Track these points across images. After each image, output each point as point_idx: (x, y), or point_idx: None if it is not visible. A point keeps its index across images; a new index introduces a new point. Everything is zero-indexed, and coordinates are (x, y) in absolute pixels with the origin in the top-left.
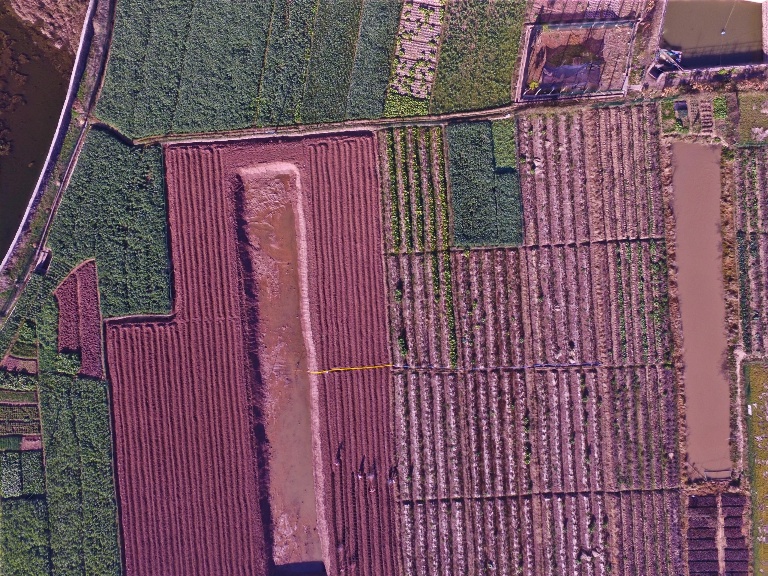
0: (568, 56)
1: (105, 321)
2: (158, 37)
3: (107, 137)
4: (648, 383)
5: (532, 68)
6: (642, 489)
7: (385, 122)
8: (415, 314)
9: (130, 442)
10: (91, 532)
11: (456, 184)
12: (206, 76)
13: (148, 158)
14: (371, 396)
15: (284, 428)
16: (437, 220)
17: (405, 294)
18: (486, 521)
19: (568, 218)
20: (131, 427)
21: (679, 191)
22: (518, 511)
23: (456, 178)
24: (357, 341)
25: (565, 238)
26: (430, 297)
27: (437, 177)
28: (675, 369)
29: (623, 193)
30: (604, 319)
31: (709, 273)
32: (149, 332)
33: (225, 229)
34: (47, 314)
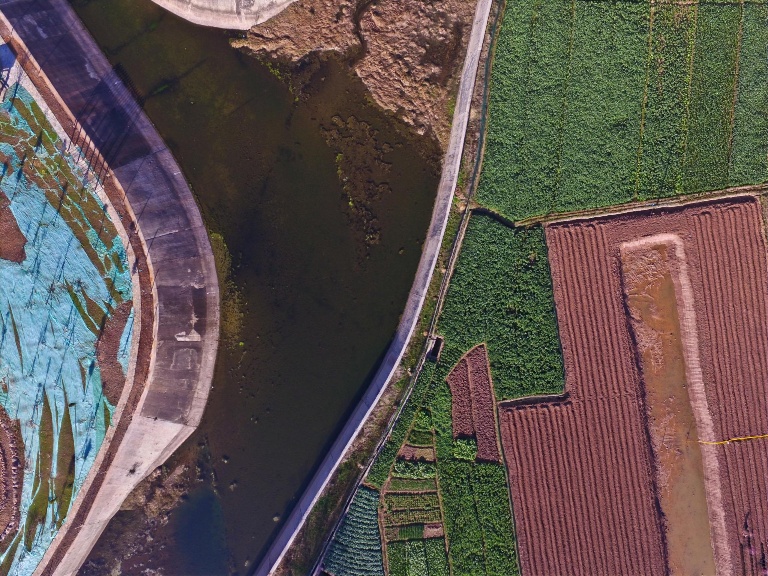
0: None
1: (497, 404)
2: (536, 119)
3: (492, 222)
4: None
5: None
6: None
7: (767, 186)
8: None
9: (532, 524)
10: None
11: None
12: (586, 154)
13: (533, 239)
14: None
15: (678, 500)
16: None
17: None
18: None
19: None
20: (533, 509)
21: None
22: None
23: None
24: (756, 409)
25: None
26: None
27: None
28: None
29: None
30: None
31: None
32: (544, 413)
33: (613, 305)
34: (441, 401)
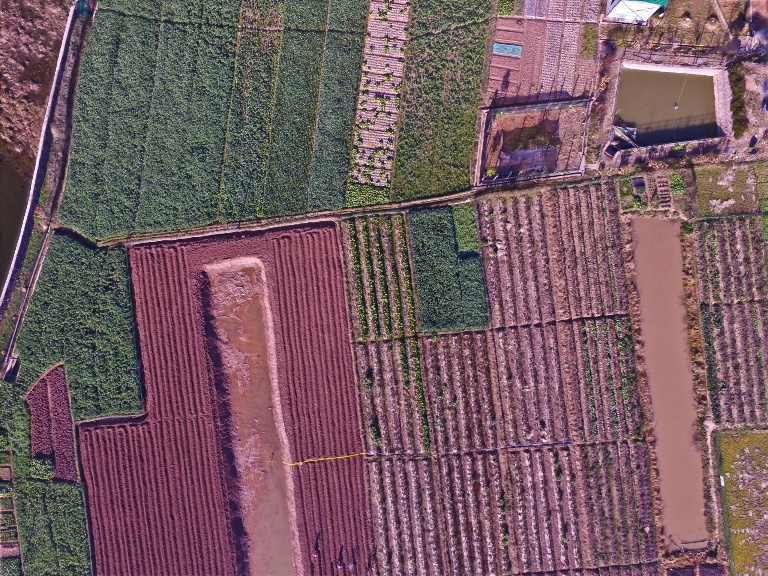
0: (524, 138)
1: (77, 424)
2: (117, 140)
3: (70, 242)
4: (620, 458)
5: (489, 152)
6: (620, 564)
7: (347, 212)
8: (386, 401)
9: (108, 544)
10: None
11: (420, 271)
12: (166, 176)
13: (112, 260)
14: (346, 485)
15: (262, 520)
16: (403, 307)
17: (375, 382)
18: None
19: (533, 298)
20: (108, 529)
21: (641, 266)
22: None
23: (420, 265)
24: (329, 431)
25: (531, 318)
26: (400, 383)
27: (401, 264)
28: (646, 443)
29: (586, 271)
30: (573, 397)
31: (675, 346)
32: (121, 433)
33: (193, 326)
34: (19, 420)
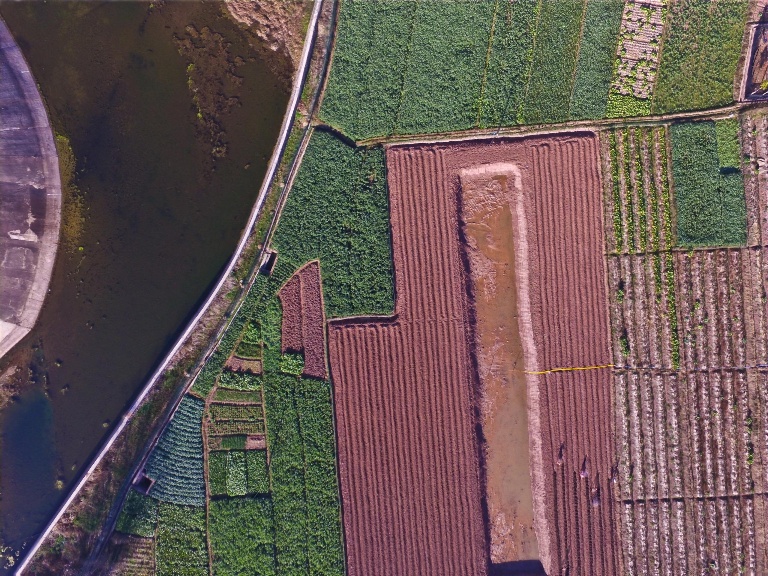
0: None
1: (327, 322)
2: (382, 39)
3: (332, 139)
4: None
5: (756, 67)
6: None
7: (607, 122)
8: (636, 314)
9: (353, 441)
10: (316, 530)
11: (680, 184)
12: (430, 77)
13: (372, 160)
14: (593, 396)
15: (501, 428)
16: (659, 220)
17: (626, 294)
18: (707, 521)
19: None
20: (355, 427)
21: None
22: (740, 511)
23: (680, 178)
24: (579, 341)
25: None
26: (651, 297)
27: (660, 177)
28: None
29: None
30: None
31: None
32: (372, 333)
33: (447, 230)
34: (271, 315)
